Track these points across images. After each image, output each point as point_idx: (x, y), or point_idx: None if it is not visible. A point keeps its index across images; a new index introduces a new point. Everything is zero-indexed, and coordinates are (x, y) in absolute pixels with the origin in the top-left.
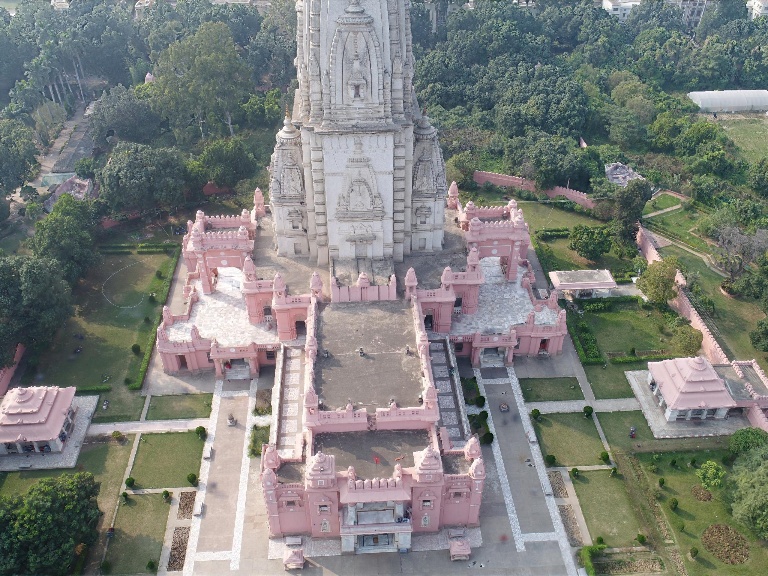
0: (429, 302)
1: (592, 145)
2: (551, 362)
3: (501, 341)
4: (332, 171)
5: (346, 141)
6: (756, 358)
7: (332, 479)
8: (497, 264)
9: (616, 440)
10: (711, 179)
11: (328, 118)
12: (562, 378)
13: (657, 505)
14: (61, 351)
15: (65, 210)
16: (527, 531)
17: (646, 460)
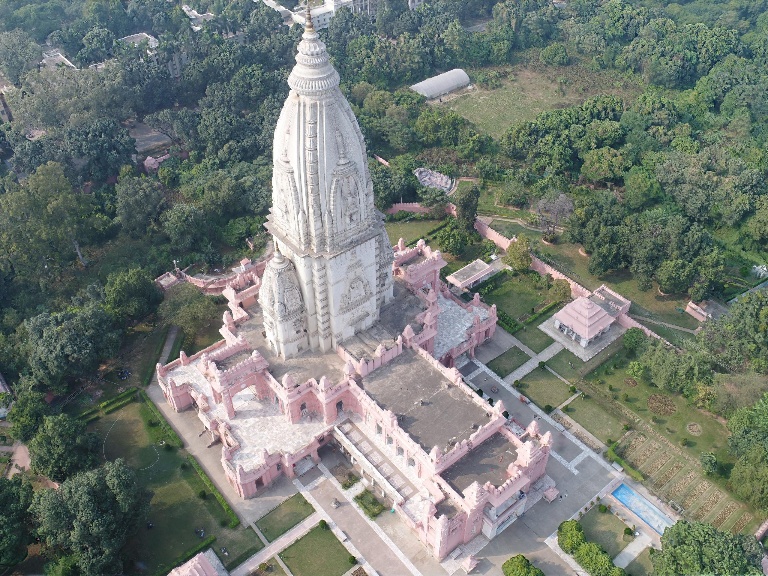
0: None
1: (390, 159)
2: (494, 343)
3: (468, 345)
4: (336, 281)
5: (345, 255)
6: (594, 281)
7: None
8: None
9: (568, 375)
10: (489, 161)
11: (332, 244)
12: (509, 350)
13: (617, 403)
14: (134, 535)
15: (32, 410)
16: (571, 460)
17: (592, 379)
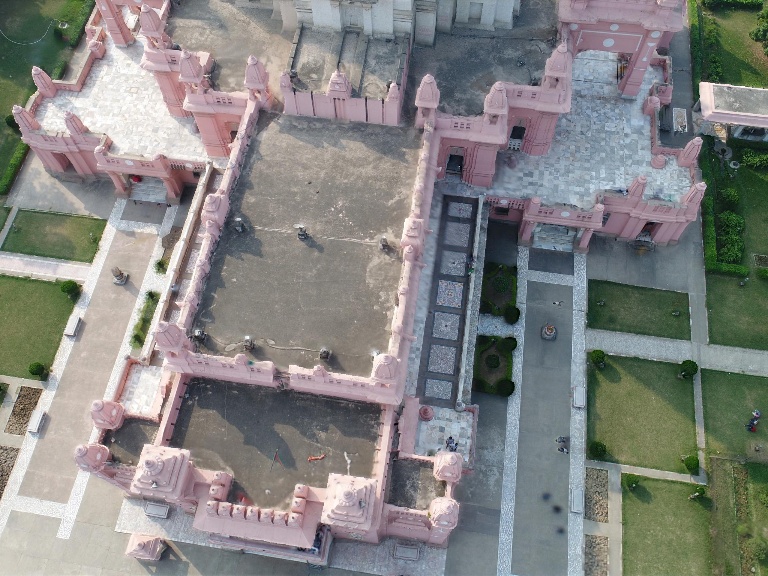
0: (457, 138)
1: None
2: (653, 257)
3: (574, 218)
4: None
5: None
6: None
7: (184, 485)
8: (611, 57)
9: (721, 430)
10: None
11: None
12: (663, 291)
13: (754, 570)
14: None
15: None
16: (521, 571)
17: (761, 479)
